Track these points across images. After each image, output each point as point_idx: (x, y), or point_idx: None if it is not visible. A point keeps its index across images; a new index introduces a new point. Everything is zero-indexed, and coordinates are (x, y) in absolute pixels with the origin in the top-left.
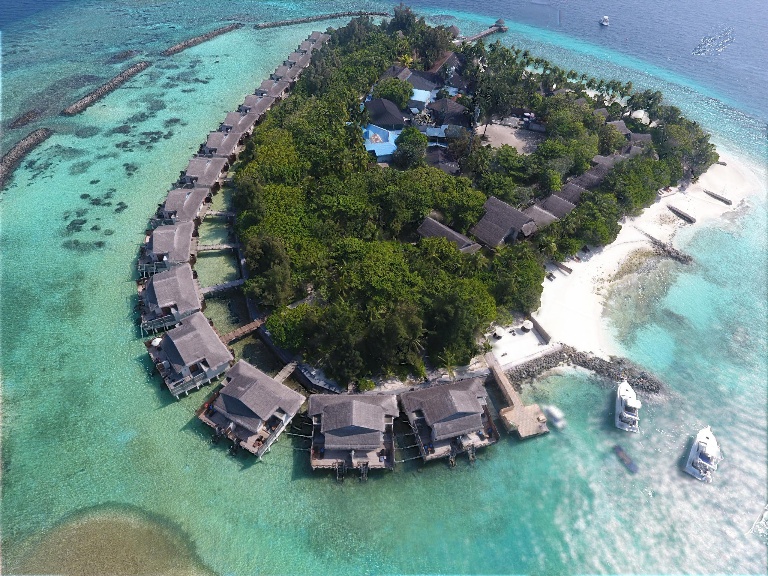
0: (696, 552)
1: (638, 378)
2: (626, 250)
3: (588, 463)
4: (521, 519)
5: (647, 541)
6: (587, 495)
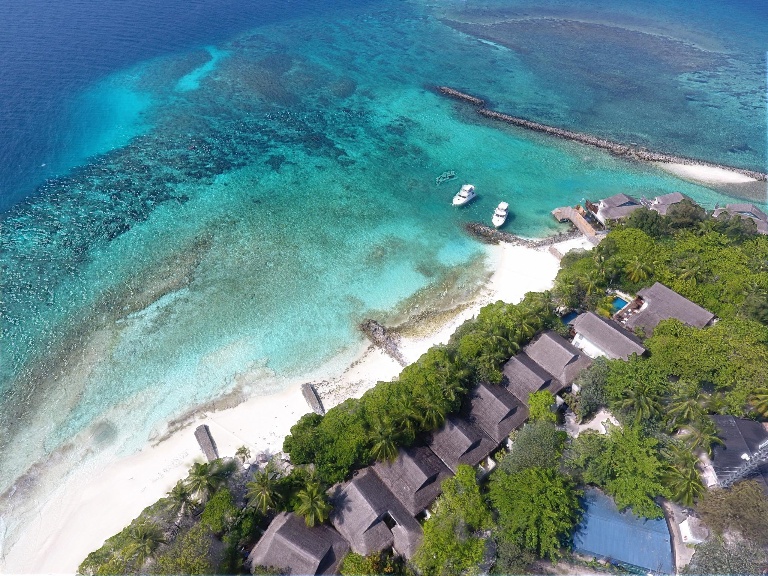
0: (484, 179)
1: (485, 229)
2: (437, 338)
3: (528, 204)
4: (567, 191)
5: (507, 182)
6: (532, 195)
